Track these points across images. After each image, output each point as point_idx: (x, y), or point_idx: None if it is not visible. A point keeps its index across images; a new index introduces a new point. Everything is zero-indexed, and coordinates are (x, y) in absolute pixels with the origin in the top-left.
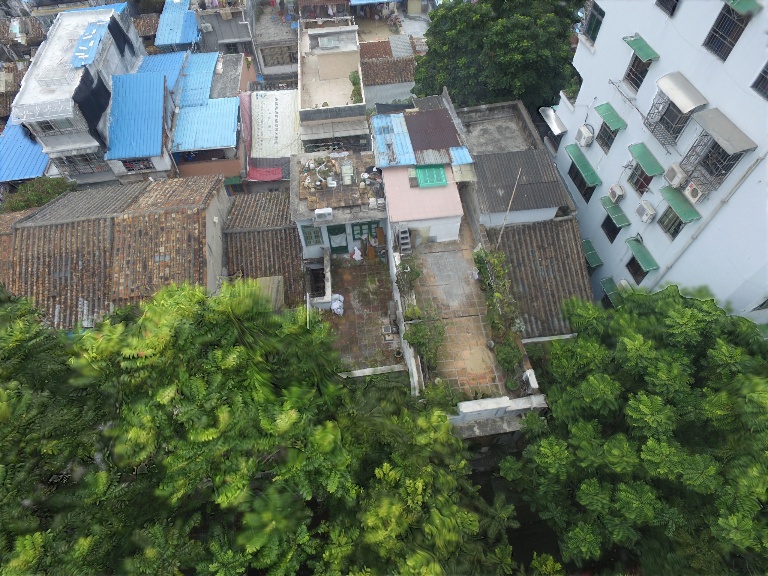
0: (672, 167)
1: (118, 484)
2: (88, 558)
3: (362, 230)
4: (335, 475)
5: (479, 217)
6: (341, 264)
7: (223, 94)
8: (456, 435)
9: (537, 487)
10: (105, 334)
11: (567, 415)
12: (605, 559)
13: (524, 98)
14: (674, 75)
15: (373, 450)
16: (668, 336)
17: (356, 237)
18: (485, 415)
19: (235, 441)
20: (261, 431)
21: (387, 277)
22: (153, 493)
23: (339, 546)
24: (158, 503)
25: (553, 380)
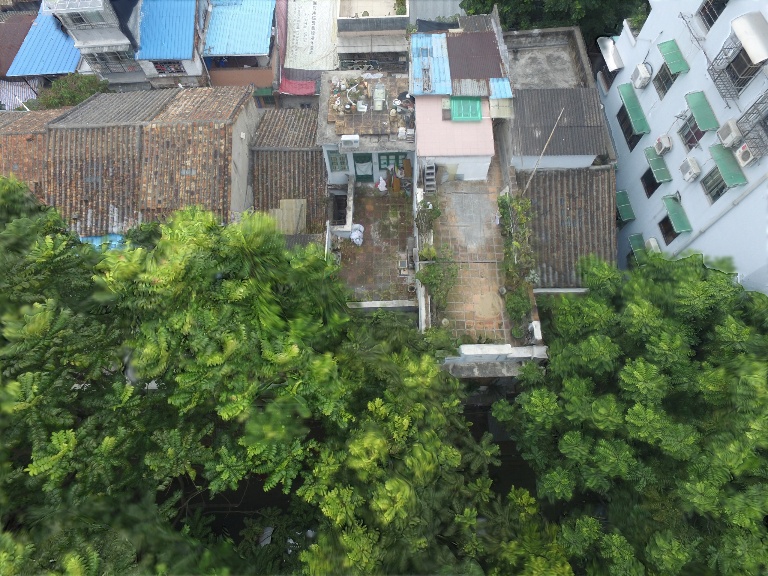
0: (728, 124)
1: (132, 396)
2: (105, 455)
3: (389, 160)
4: (330, 404)
5: (511, 158)
6: (365, 193)
7: None
8: (456, 374)
9: (524, 431)
10: (121, 260)
11: (564, 370)
12: (577, 500)
13: (584, 23)
14: (753, 16)
15: (369, 385)
16: (679, 307)
17: (382, 167)
18: (486, 358)
19: (237, 368)
20: (262, 361)
21: (410, 211)
22: (162, 406)
23: (327, 465)
24: (166, 415)
25: None
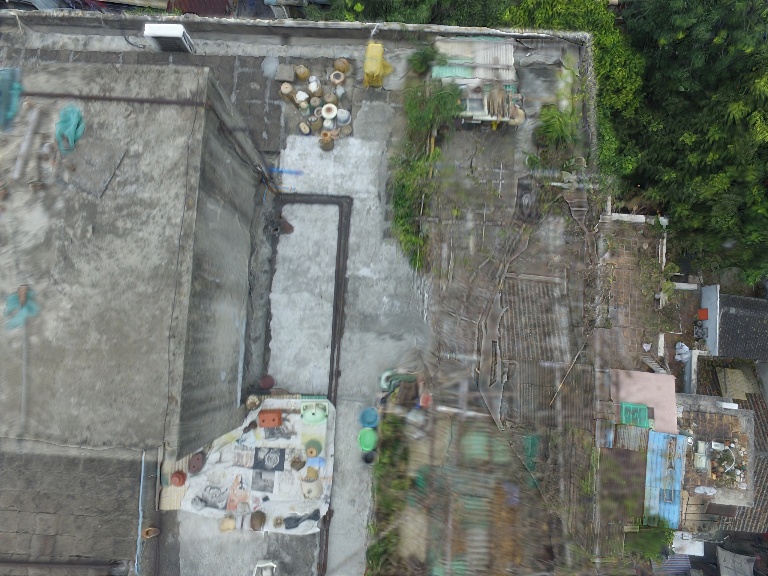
0: None
1: None
2: None
3: None
4: None
5: None
6: None
7: None
8: None
9: None
10: None
11: None
12: None
13: None
14: None
15: (767, 153)
16: None
17: None
18: None
19: None
20: None
21: None
22: None
23: None
24: None
25: (545, 248)
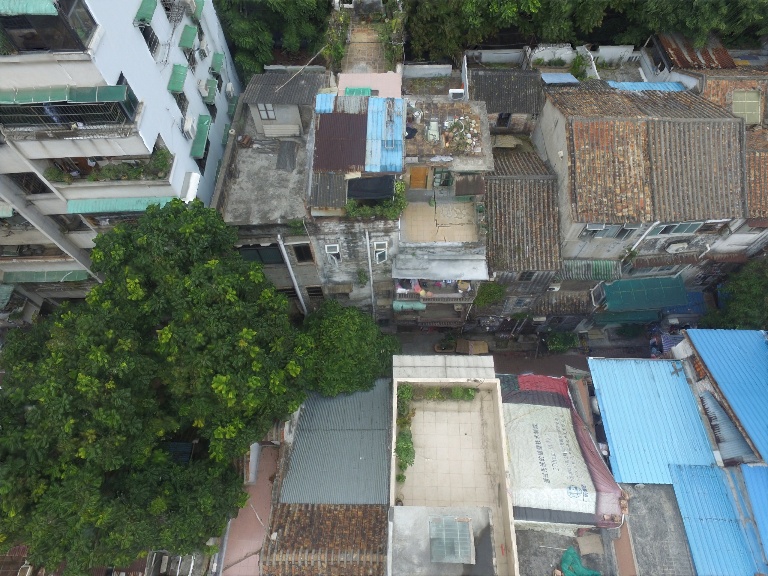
0: None
1: None
2: None
3: None
4: None
5: None
6: None
7: (654, 511)
8: None
9: None
10: None
11: None
12: None
13: None
14: None
15: None
16: None
17: None
18: None
19: None
20: None
21: None
22: None
23: None
24: None
25: None
